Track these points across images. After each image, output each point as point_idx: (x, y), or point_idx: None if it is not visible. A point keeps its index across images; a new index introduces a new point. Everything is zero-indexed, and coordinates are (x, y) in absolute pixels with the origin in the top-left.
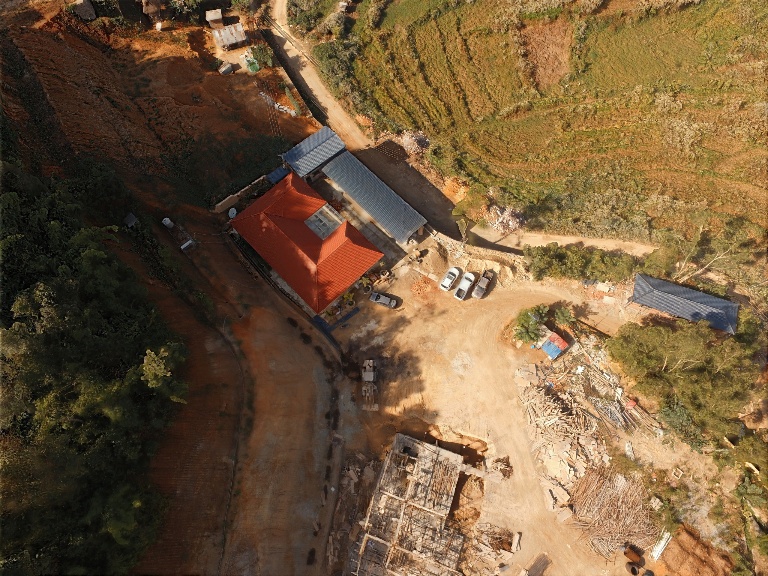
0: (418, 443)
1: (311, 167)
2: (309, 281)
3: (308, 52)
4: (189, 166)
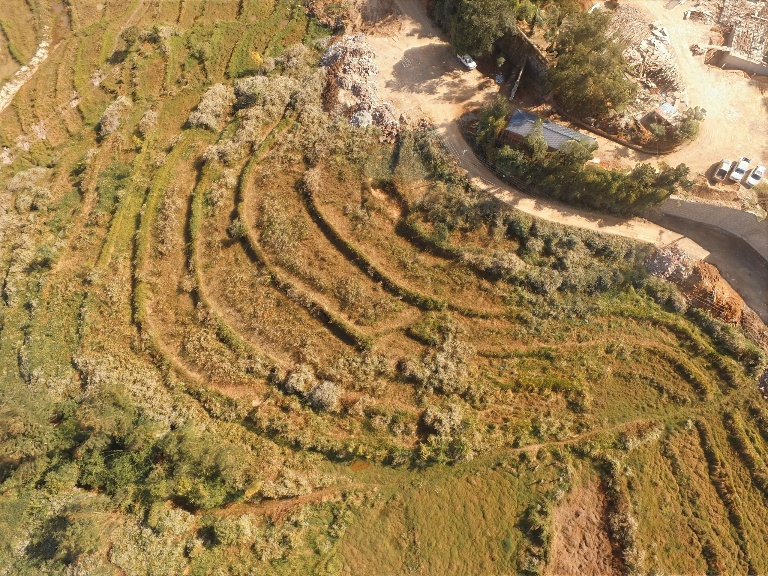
0: (765, 64)
1: None
2: None
3: None
4: None
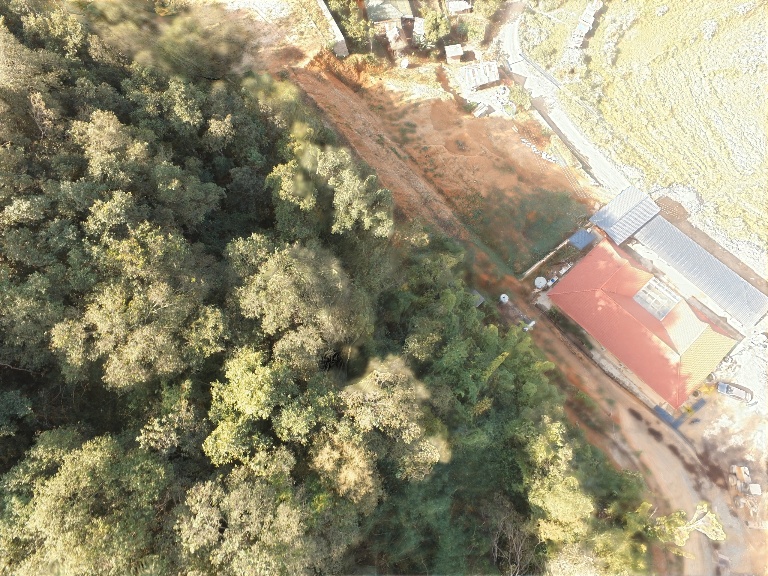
0: None
1: (627, 234)
2: (666, 372)
3: (552, 92)
4: (482, 226)
